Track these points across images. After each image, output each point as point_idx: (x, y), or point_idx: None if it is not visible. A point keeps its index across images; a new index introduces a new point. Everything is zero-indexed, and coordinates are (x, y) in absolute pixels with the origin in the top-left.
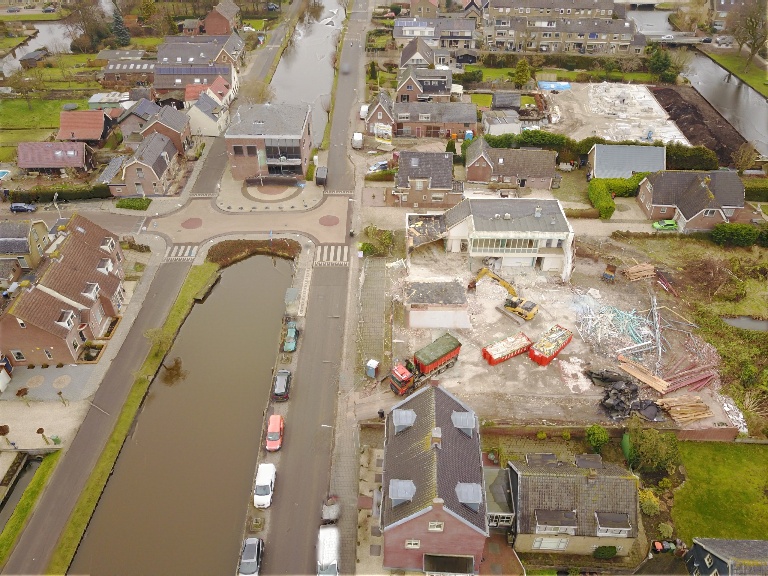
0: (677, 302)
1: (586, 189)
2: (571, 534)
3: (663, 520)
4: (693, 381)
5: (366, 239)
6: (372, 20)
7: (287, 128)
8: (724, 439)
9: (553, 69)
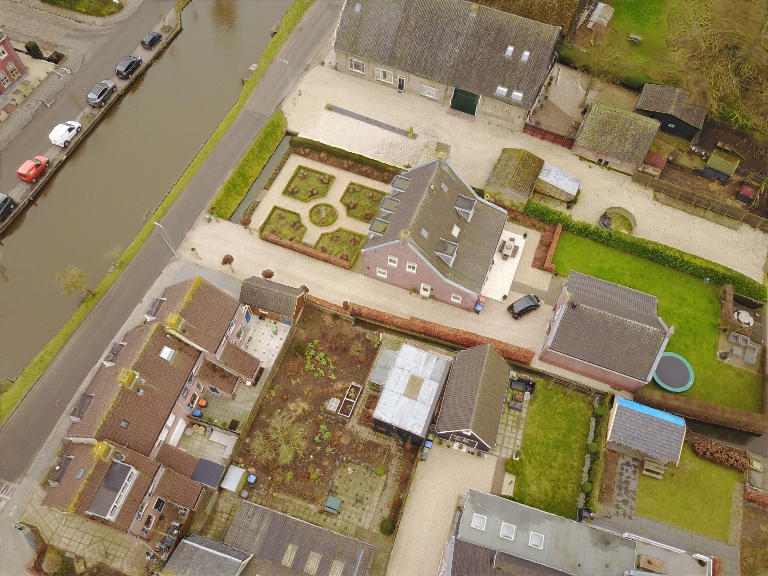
0: None
1: None
2: None
3: None
4: None
5: None
6: None
7: None
8: None
9: None
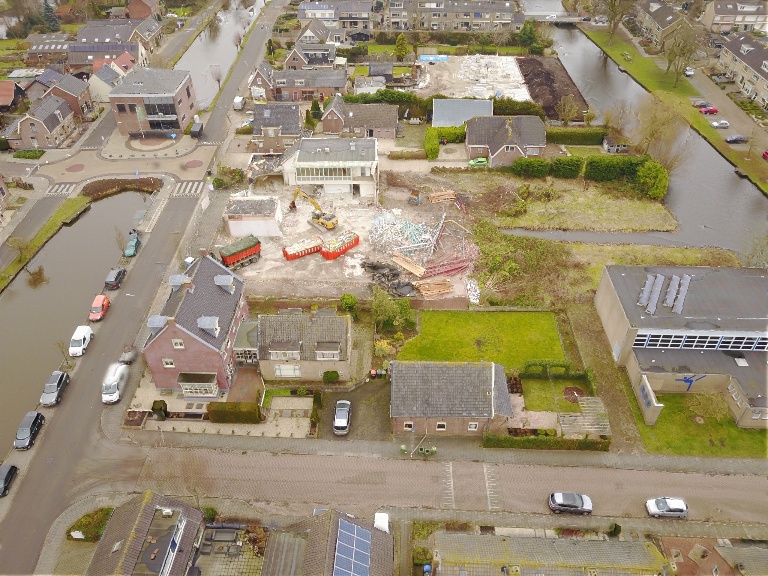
0: (464, 217)
1: None
2: (297, 359)
3: (389, 360)
4: (449, 269)
5: (221, 177)
6: None
7: (162, 88)
8: (460, 308)
9: (438, 45)
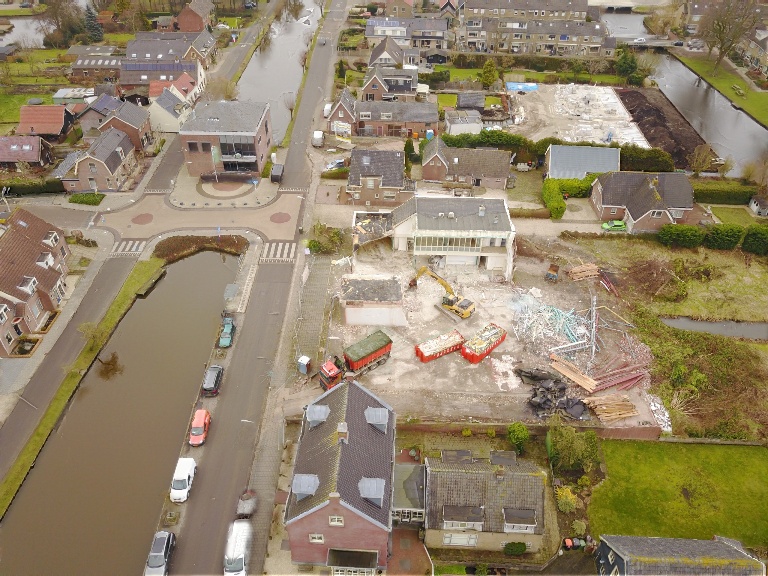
0: (617, 302)
1: (541, 189)
2: (478, 530)
3: (578, 517)
4: (623, 380)
5: (315, 236)
6: (348, 19)
7: (241, 125)
8: (648, 438)
9: (523, 70)
